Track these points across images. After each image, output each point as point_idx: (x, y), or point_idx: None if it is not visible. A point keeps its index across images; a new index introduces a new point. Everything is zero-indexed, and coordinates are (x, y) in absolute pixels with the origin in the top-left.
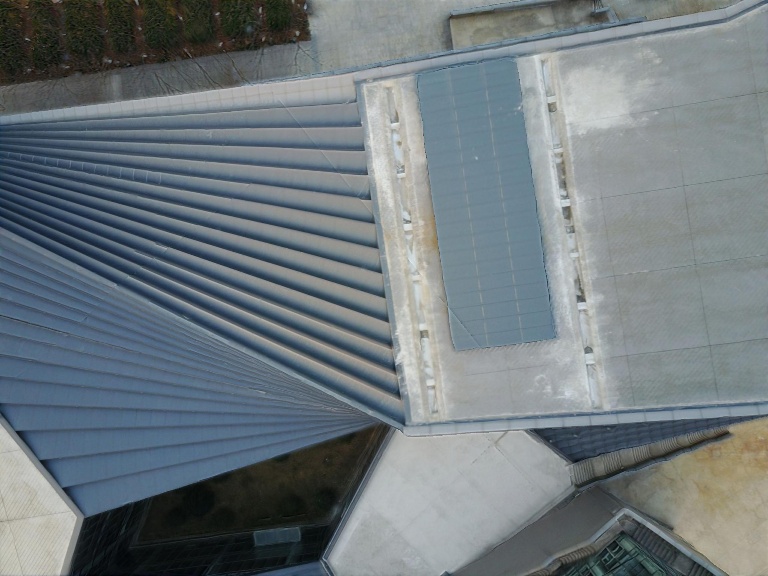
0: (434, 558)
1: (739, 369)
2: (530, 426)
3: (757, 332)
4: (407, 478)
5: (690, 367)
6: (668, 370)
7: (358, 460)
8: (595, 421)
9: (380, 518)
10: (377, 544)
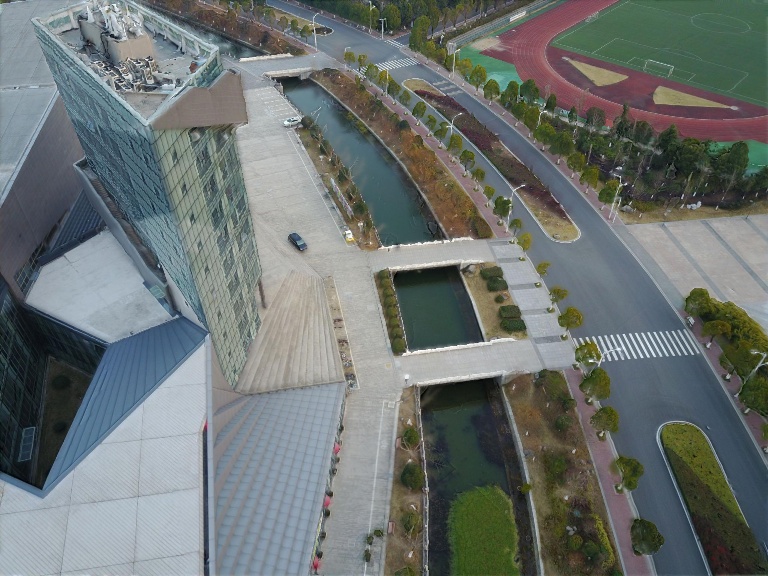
0: (132, 289)
1: (19, 130)
2: (8, 192)
3: (5, 125)
4: (71, 302)
5: (9, 143)
6: (6, 149)
7: (89, 376)
8: (18, 170)
9: (92, 315)
10: (110, 317)
